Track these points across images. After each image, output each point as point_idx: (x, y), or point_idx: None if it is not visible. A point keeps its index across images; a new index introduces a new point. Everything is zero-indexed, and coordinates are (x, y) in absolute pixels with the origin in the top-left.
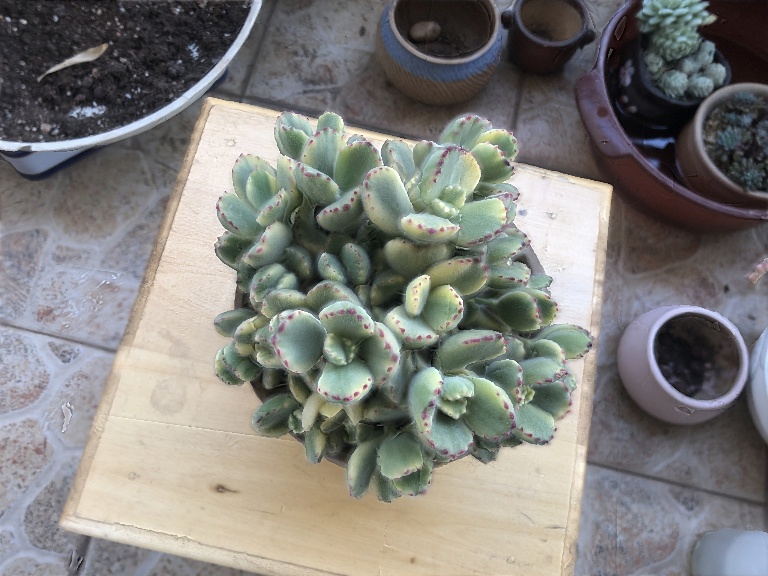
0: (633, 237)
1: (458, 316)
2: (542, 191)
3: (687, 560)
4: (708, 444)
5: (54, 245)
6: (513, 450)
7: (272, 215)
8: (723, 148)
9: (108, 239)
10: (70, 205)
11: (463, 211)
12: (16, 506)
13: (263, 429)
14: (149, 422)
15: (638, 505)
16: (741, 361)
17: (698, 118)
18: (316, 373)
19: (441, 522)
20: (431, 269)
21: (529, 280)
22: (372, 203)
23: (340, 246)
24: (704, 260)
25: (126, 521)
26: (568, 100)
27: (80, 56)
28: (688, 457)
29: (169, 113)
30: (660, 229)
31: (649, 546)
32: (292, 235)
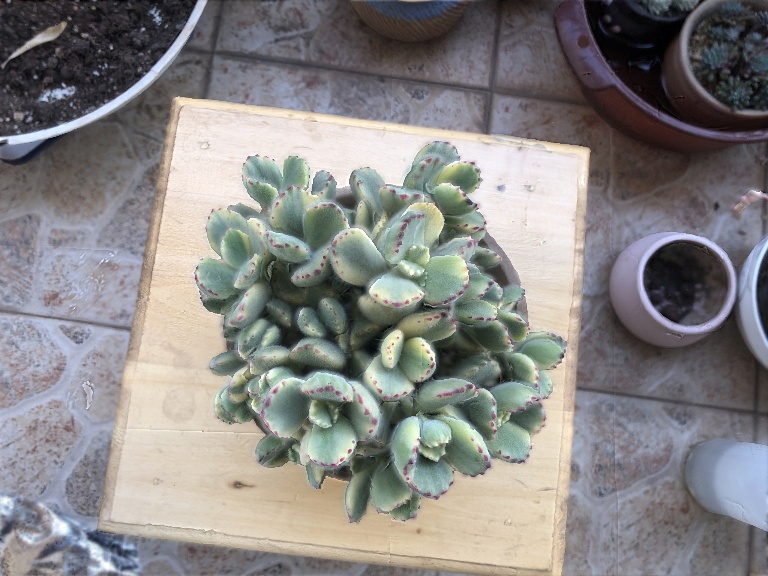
0: (622, 162)
1: (431, 371)
2: (519, 163)
3: (681, 470)
4: (700, 361)
5: (48, 229)
6: None
7: (248, 282)
8: (709, 67)
9: (100, 217)
10: (57, 186)
11: (428, 268)
12: (56, 480)
13: (266, 462)
14: (164, 431)
15: (634, 424)
16: (729, 284)
17: (684, 35)
18: (307, 418)
19: (442, 495)
20: (403, 323)
21: (501, 300)
22: (341, 268)
23: (317, 298)
24: (694, 179)
25: (157, 522)
26: (550, 20)
27: (40, 36)
28: (681, 375)
29: (140, 89)
30: (649, 151)
31: (645, 460)
32: (271, 289)
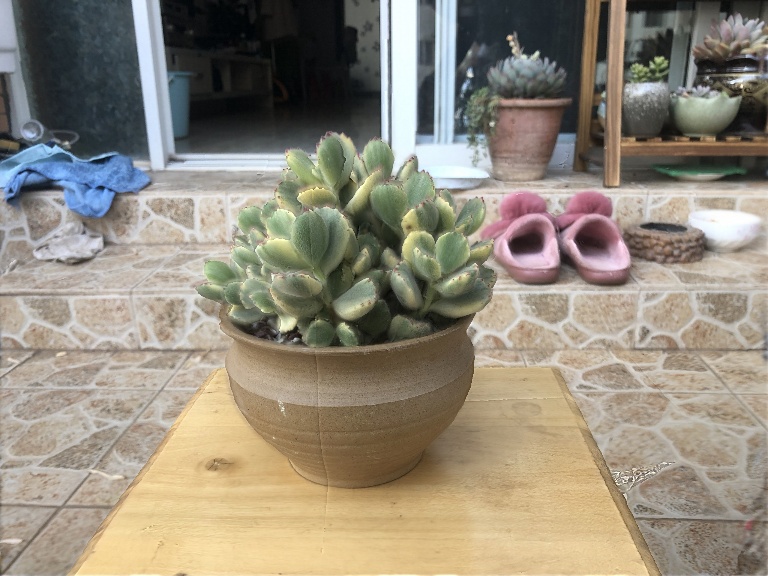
0: None
1: None
2: None
3: None
4: None
5: None
6: (235, 418)
7: None
8: None
9: None
10: None
11: None
12: None
13: None
14: None
15: None
16: None
17: None
18: None
19: None
20: None
21: None
22: None
23: None
24: None
25: None
26: None
27: None
28: None
29: None
30: None
31: None
32: None
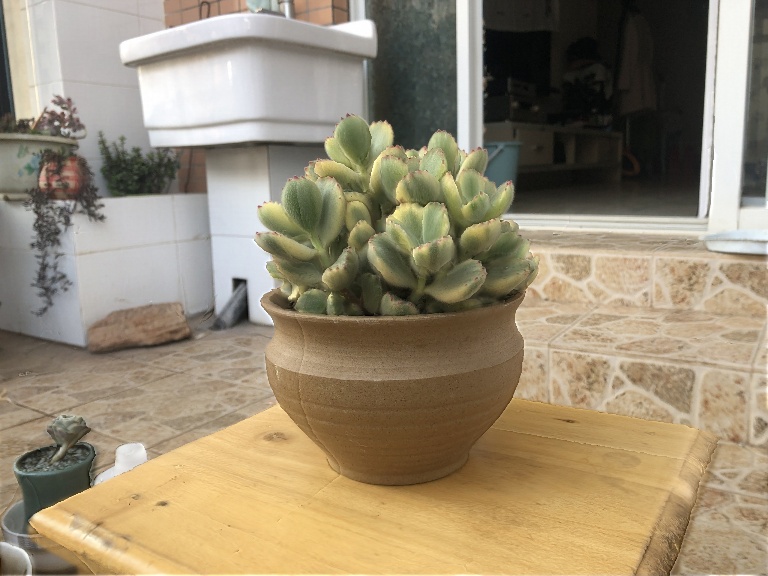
0: None
1: None
2: (117, 515)
3: None
4: None
5: None
6: None
7: None
8: None
9: None
10: None
11: None
12: None
13: None
14: None
15: None
16: None
17: None
18: None
19: None
20: None
21: None
22: None
23: None
24: None
25: None
26: None
27: None
28: None
29: None
30: None
31: None
32: None
